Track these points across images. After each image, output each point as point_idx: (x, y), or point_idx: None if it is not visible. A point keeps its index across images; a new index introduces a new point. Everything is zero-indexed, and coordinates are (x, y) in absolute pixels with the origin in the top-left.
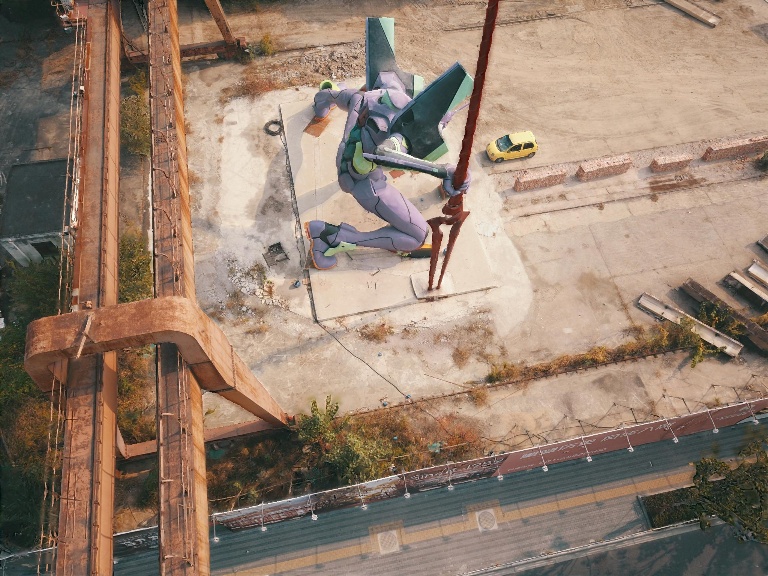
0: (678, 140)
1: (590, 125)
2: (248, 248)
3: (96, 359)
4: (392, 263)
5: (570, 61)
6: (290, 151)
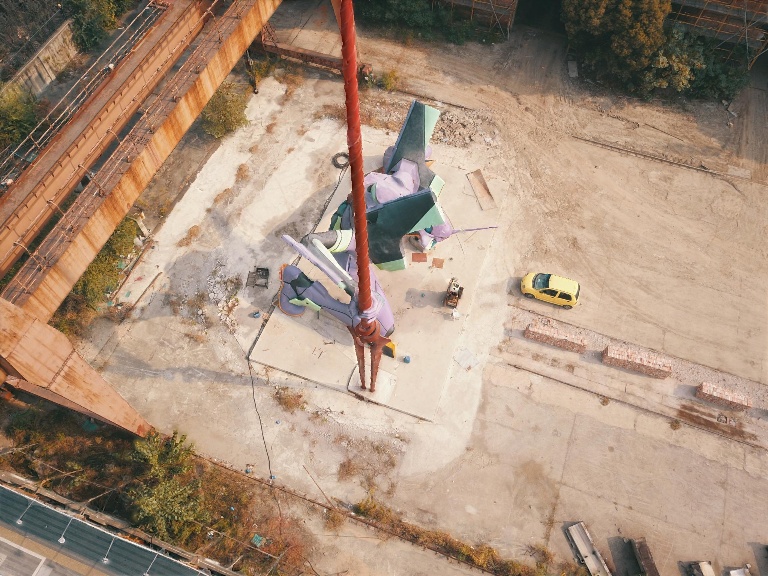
0: (755, 375)
1: (659, 307)
2: (242, 260)
3: None
4: (350, 342)
5: (689, 227)
6: (339, 189)
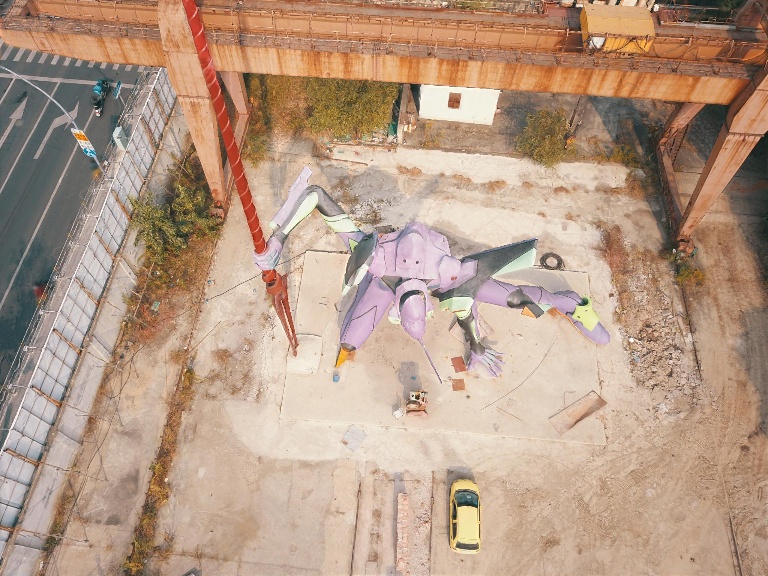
0: None
1: None
2: (401, 216)
3: (199, 4)
4: None
5: None
6: None
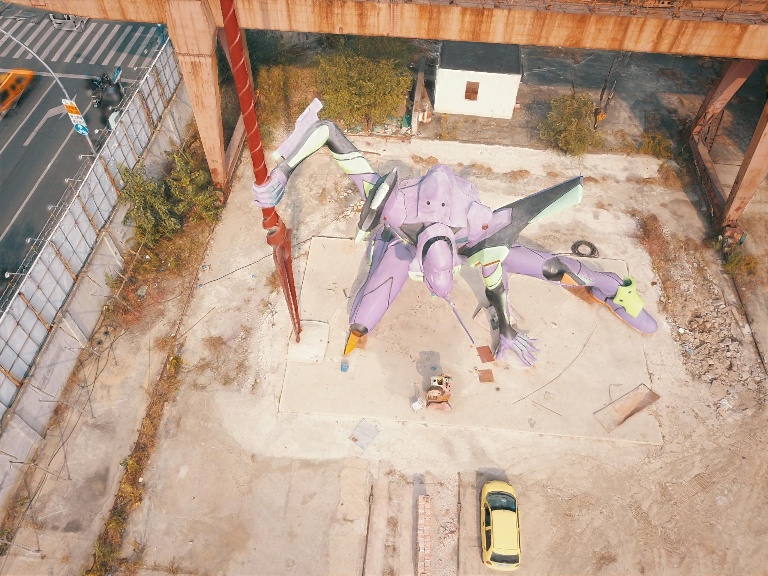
0: None
1: None
2: None
3: None
4: None
5: None
6: None
